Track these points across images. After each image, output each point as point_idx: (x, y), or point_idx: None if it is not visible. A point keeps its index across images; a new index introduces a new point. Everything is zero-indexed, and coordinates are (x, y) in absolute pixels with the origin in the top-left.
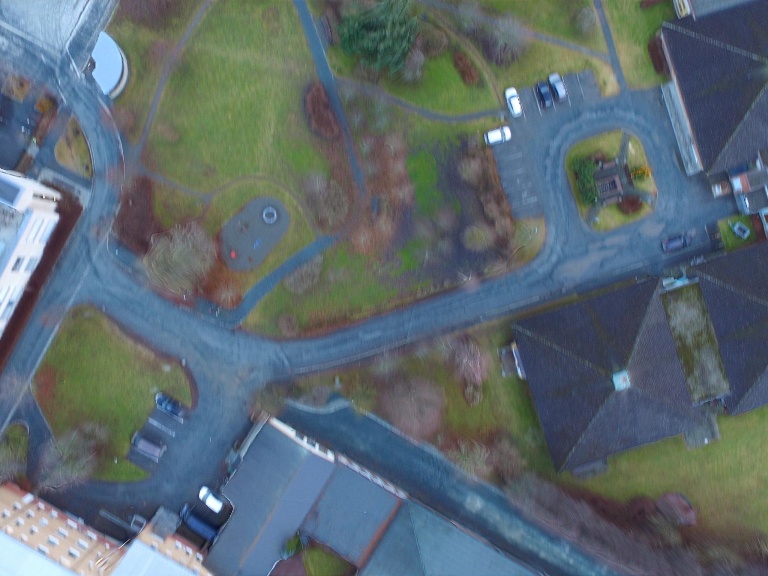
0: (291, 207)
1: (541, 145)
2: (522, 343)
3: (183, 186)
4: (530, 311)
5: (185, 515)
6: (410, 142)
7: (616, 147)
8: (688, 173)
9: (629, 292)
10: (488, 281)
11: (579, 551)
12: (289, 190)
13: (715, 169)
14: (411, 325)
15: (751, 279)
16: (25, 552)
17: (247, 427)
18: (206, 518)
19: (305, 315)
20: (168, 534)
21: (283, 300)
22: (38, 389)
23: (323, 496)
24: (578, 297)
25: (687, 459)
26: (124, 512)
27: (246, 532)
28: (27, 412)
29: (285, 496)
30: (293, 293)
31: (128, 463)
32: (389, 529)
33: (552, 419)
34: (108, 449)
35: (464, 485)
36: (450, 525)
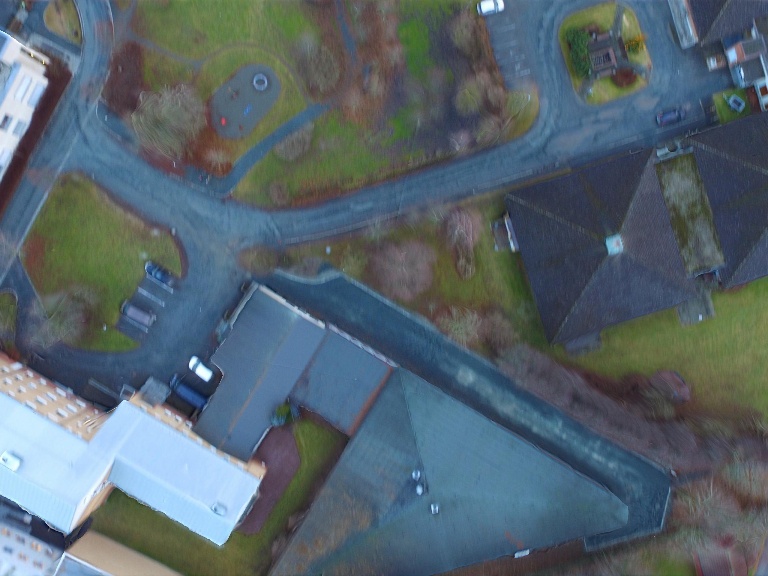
0: (282, 75)
1: (534, 17)
2: (515, 212)
3: (173, 53)
4: (523, 184)
5: (175, 384)
6: (402, 10)
7: (610, 19)
8: (683, 46)
9: (623, 161)
10: (481, 154)
11: (572, 426)
12: (280, 57)
13: (710, 37)
14: (403, 197)
15: (746, 147)
16: (12, 404)
17: (237, 297)
18: (196, 387)
19: (296, 184)
20: (157, 402)
21: (274, 169)
22: (27, 257)
23: (313, 363)
24: (571, 170)
25: (681, 336)
26: (113, 382)
27: (236, 397)
28: (16, 280)
29: (275, 361)
30: (284, 160)
31: (117, 333)
32: (380, 396)
33: (545, 289)
34: (97, 318)
35: (456, 358)
36: (441, 393)
